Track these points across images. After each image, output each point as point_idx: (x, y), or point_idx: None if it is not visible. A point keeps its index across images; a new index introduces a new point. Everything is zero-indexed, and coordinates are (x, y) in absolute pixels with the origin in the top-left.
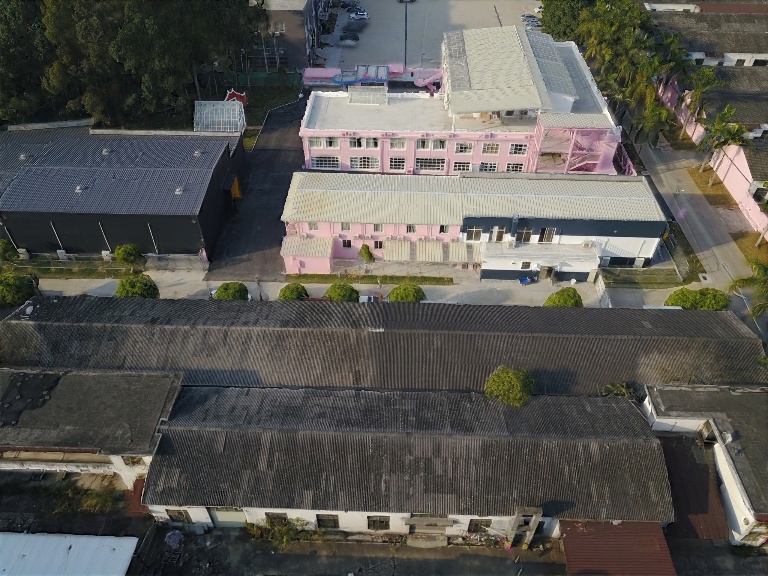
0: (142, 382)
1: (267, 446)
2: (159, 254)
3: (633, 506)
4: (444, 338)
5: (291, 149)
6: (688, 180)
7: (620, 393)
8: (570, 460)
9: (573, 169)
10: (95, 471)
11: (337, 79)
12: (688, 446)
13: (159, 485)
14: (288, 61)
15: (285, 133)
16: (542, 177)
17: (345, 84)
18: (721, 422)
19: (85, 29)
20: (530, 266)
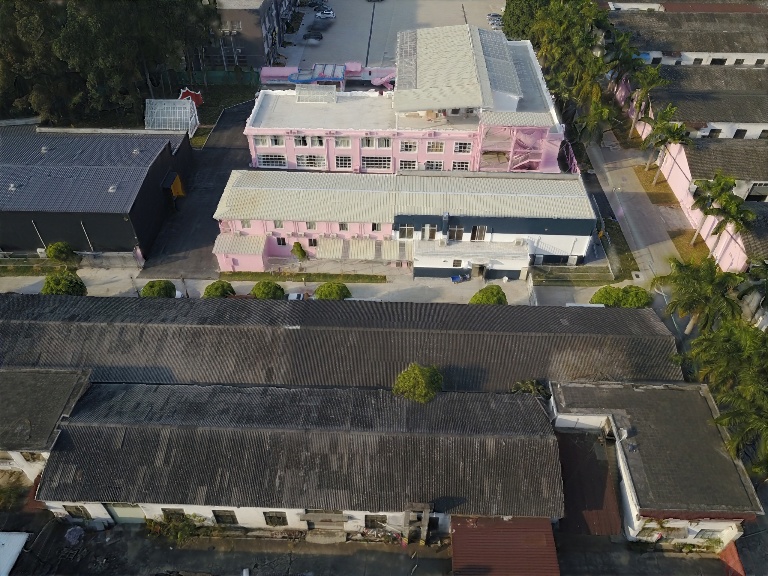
0: (49, 379)
1: (165, 442)
2: (93, 252)
3: (524, 502)
4: (359, 335)
5: (241, 147)
6: (633, 178)
7: (527, 390)
8: (465, 456)
9: (516, 167)
10: (3, 467)
11: (293, 78)
12: (590, 442)
13: (54, 481)
14: (246, 60)
15: (237, 131)
16: (479, 175)
17: (302, 83)
18: (620, 418)
19: (25, 27)
20: (461, 264)
